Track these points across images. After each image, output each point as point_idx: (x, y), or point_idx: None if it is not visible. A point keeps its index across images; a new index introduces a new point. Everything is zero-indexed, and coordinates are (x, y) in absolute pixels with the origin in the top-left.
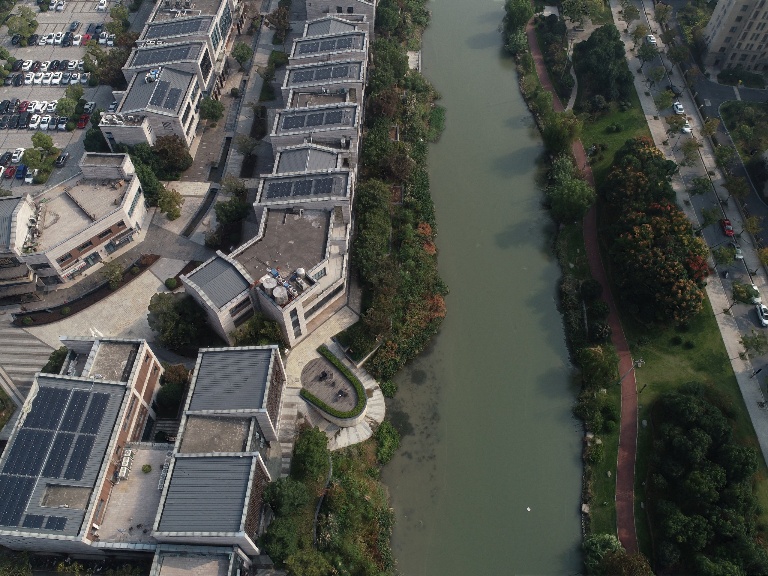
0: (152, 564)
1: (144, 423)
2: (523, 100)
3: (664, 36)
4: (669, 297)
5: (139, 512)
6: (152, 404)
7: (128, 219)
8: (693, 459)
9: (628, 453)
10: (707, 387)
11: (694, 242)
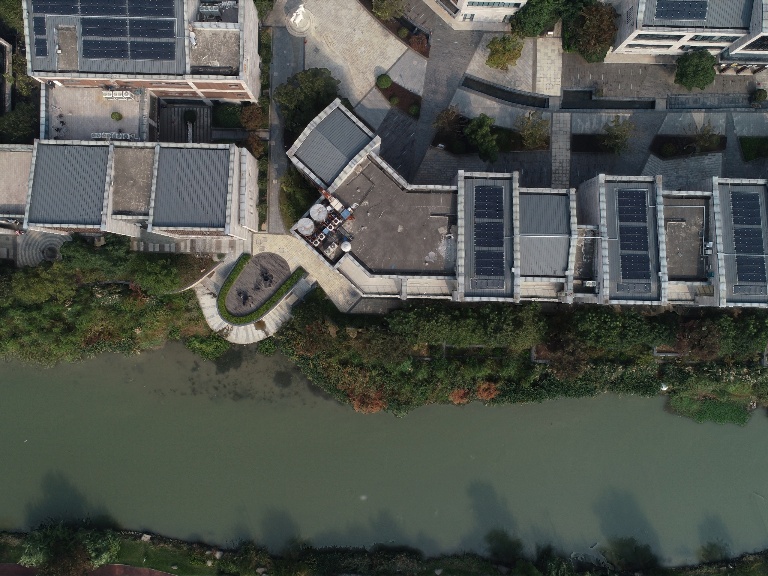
0: (25, 144)
1: (189, 97)
2: None
3: None
4: None
5: (78, 119)
6: (214, 100)
7: (464, 4)
8: None
9: None
10: None
11: None
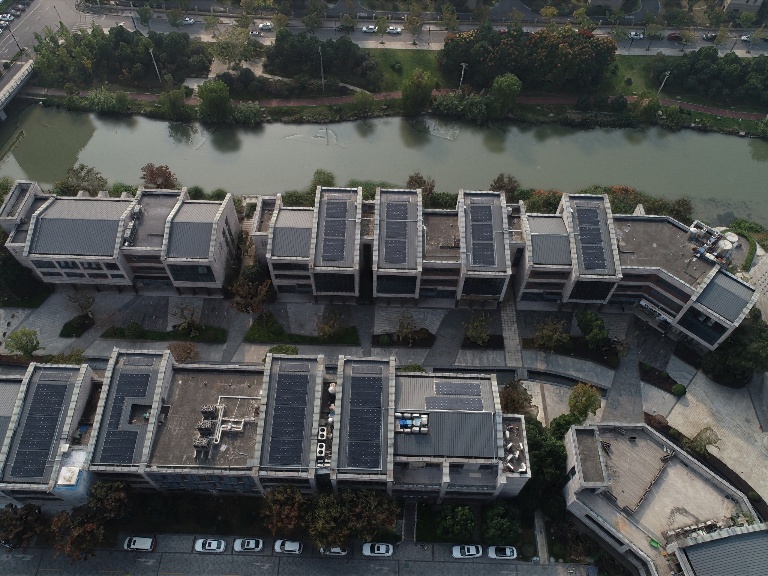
0: None
1: None
2: (338, 123)
3: (284, 11)
4: (615, 52)
5: None
6: None
7: None
8: (715, 71)
9: (701, 108)
10: (645, 67)
11: (568, 30)
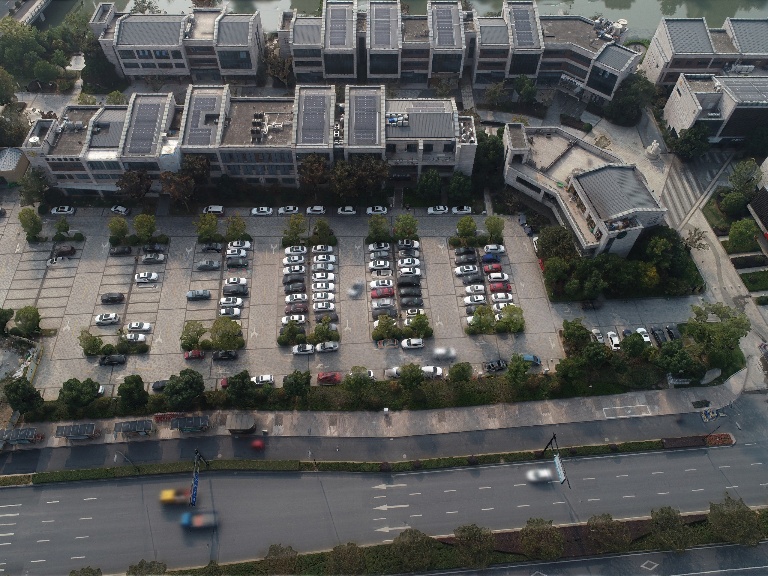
0: None
1: None
2: None
3: None
4: None
5: None
6: None
7: None
8: None
9: None
10: None
11: None
